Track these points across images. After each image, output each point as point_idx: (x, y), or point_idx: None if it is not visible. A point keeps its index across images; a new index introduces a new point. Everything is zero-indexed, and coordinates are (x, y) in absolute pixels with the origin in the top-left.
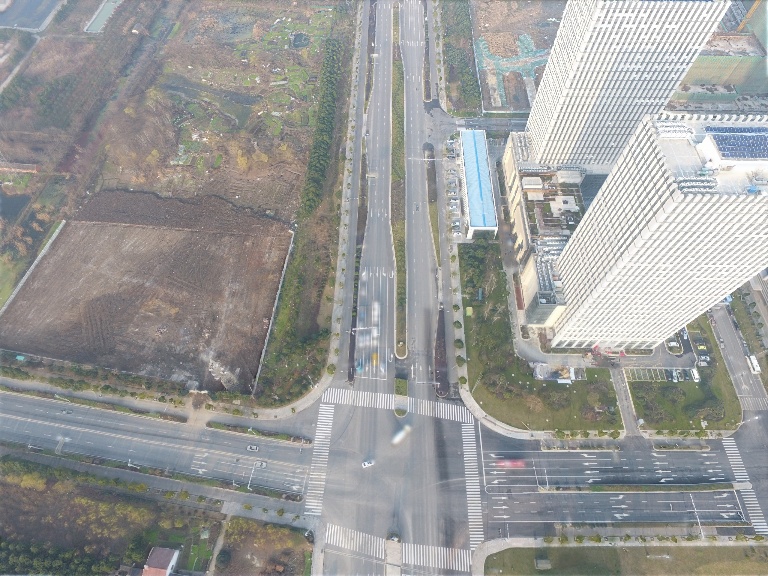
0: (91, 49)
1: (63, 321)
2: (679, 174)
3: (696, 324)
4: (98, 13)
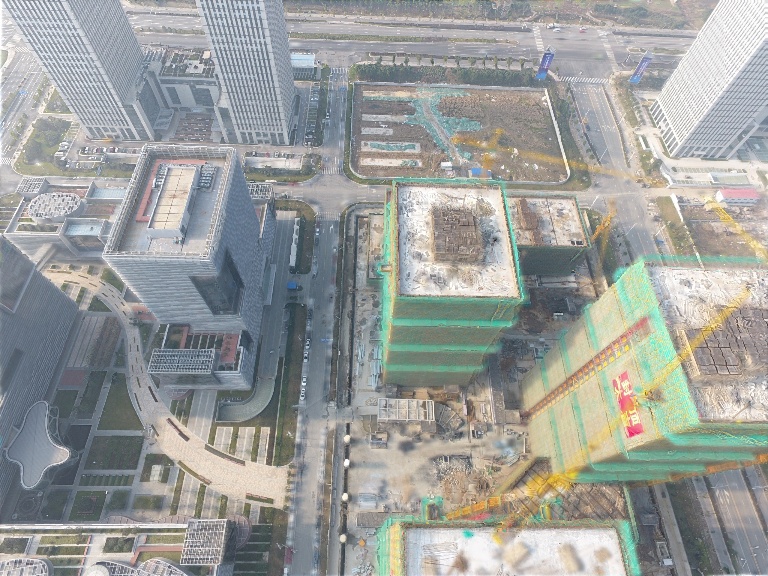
0: None
1: None
2: None
3: (97, 166)
4: None
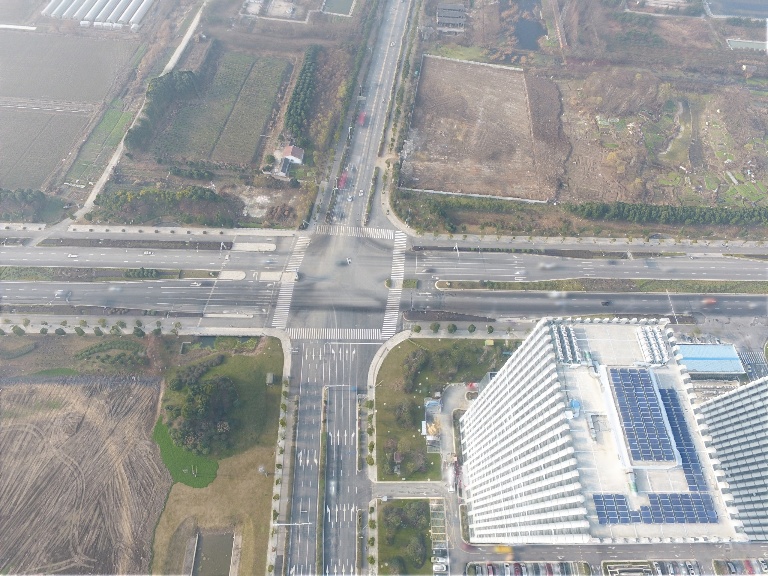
0: (706, 47)
1: (444, 86)
2: (582, 335)
3: None
4: (756, 42)
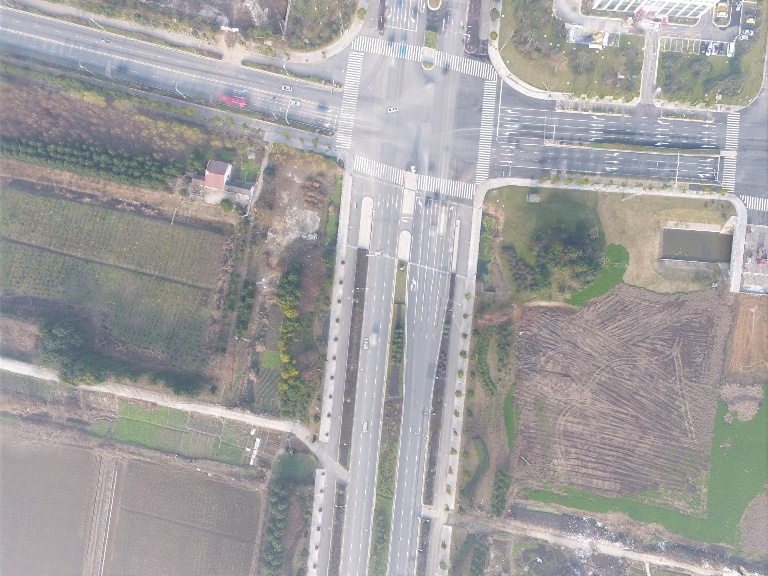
0: None
1: None
2: None
3: None
4: None
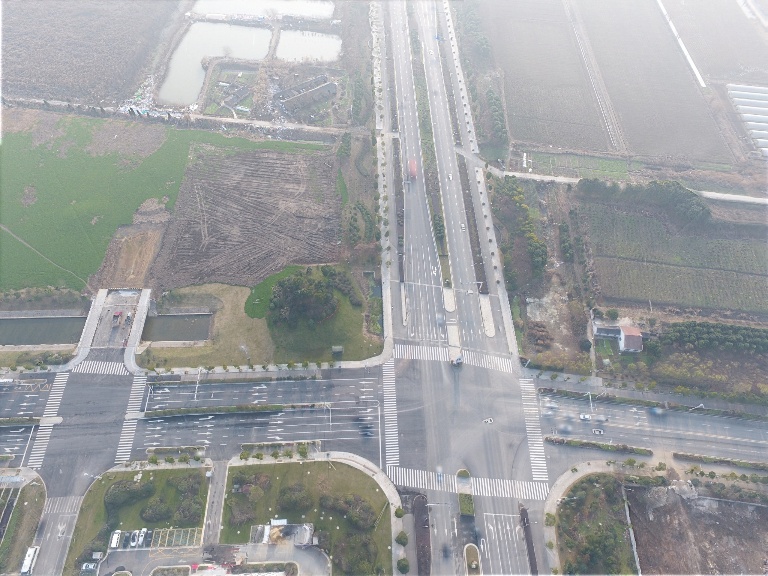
0: None
1: None
2: None
3: None
4: None
